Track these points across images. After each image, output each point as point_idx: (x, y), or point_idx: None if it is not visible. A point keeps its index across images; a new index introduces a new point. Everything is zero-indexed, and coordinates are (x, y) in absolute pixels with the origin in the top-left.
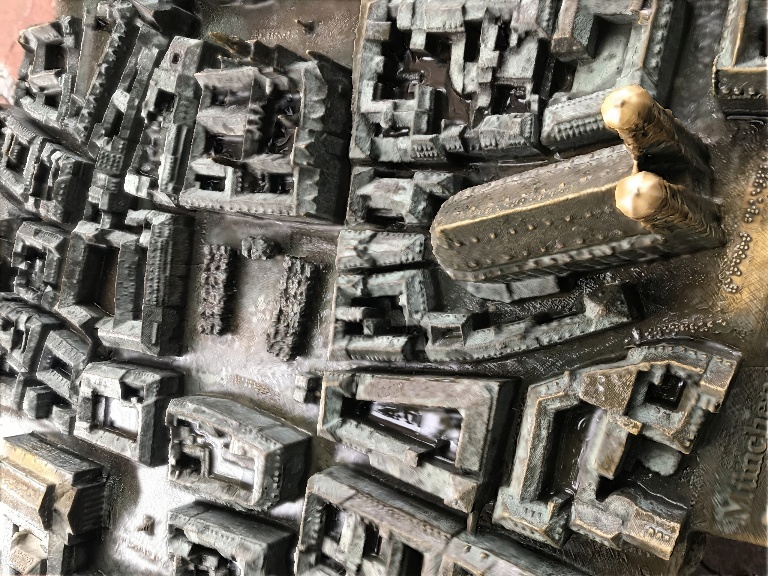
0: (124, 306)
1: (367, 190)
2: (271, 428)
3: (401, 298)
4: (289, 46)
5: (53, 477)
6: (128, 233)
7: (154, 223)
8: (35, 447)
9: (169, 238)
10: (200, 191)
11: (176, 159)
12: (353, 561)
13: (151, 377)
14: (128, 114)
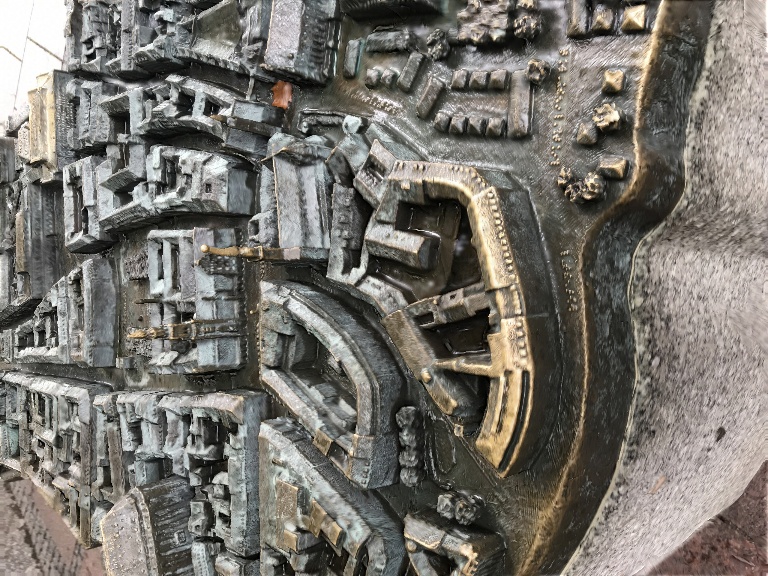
0: (113, 184)
1: (169, 417)
2: (103, 346)
3: (139, 448)
4: (258, 289)
5: (51, 152)
6: (146, 157)
7: (142, 202)
8: (64, 104)
9: (144, 217)
10: (155, 254)
11: (172, 209)
12: (73, 427)
13: (95, 233)
14: (189, 123)
